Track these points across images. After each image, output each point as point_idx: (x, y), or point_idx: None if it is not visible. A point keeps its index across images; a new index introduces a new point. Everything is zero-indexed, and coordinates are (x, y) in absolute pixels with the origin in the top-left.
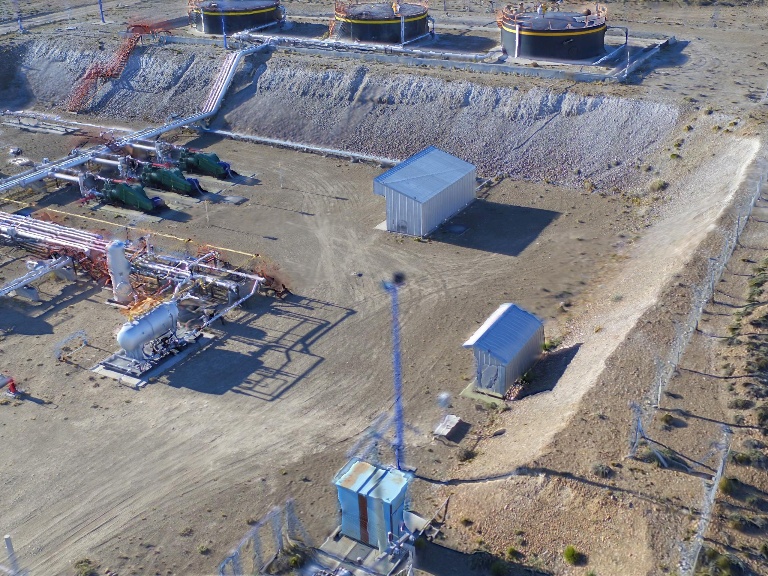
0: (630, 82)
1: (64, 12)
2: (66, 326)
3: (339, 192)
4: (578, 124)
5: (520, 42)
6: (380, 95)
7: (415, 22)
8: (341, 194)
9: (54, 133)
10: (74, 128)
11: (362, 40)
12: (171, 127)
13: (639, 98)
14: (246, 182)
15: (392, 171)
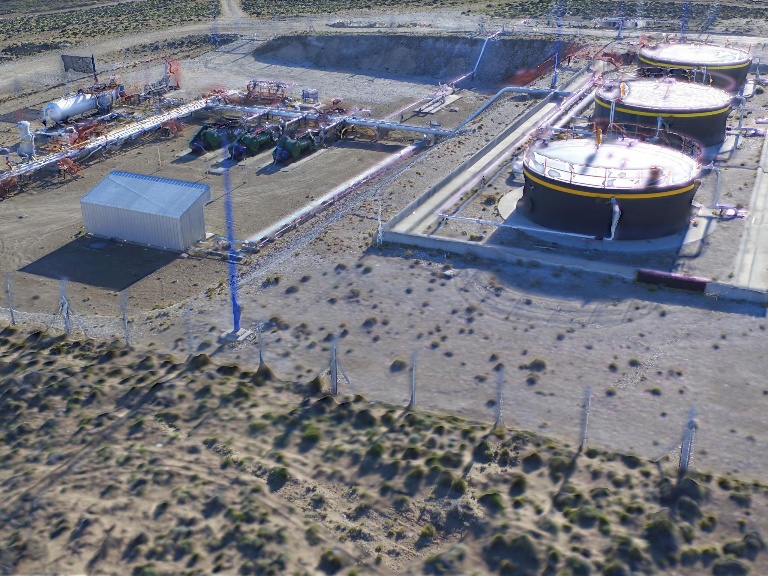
0: (380, 247)
1: (760, 38)
2: (2, 156)
3: (229, 201)
4: None
5: None
6: None
7: (634, 116)
8: (223, 202)
9: (417, 108)
10: (432, 111)
11: None
12: (392, 126)
13: (296, 253)
14: (266, 170)
15: (136, 176)
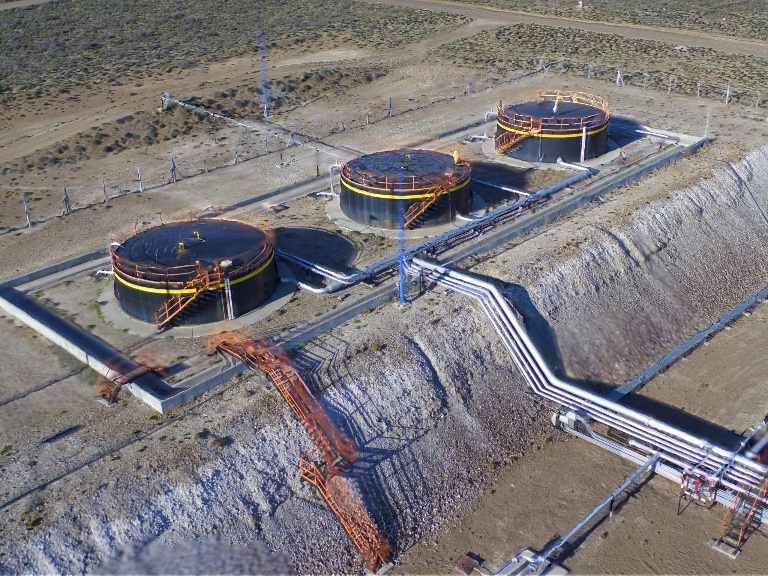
0: None
1: None
2: None
3: None
4: (763, 184)
5: (586, 144)
6: (653, 243)
7: None
8: None
9: None
10: None
11: (459, 210)
12: None
13: None
14: None
15: None
